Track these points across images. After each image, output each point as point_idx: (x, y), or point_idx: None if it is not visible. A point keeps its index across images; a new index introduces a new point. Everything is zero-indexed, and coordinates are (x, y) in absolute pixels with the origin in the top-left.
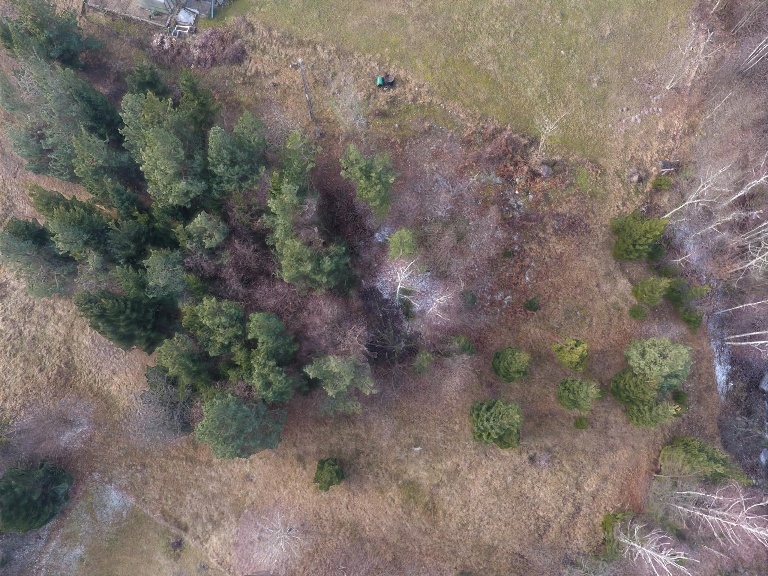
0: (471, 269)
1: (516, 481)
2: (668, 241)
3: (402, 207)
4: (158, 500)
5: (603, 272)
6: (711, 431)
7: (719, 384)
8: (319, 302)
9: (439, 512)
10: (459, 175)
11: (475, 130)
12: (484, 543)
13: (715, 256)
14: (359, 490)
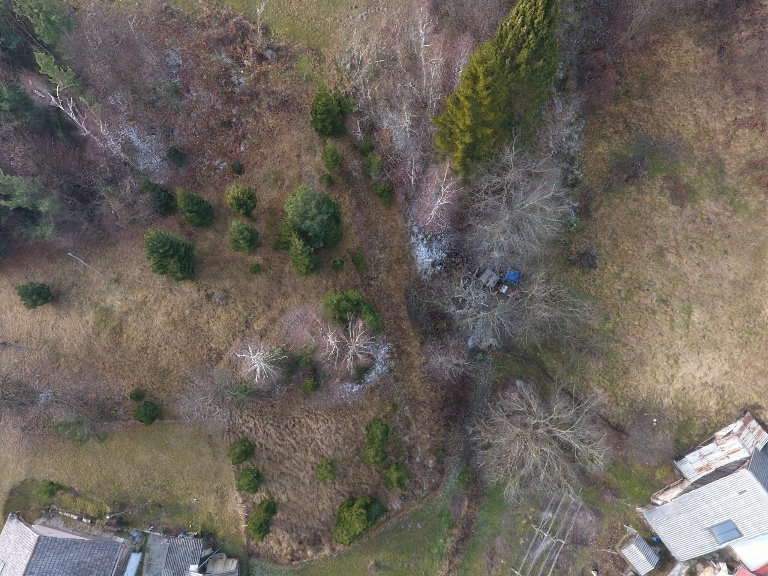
0: (193, 136)
1: (193, 315)
2: (372, 124)
3: (134, 75)
4: None
5: (307, 146)
6: (398, 300)
7: (420, 263)
8: (3, 126)
9: (124, 335)
10: (190, 52)
11: (210, 14)
12: (161, 367)
13: (425, 146)
14: (65, 314)
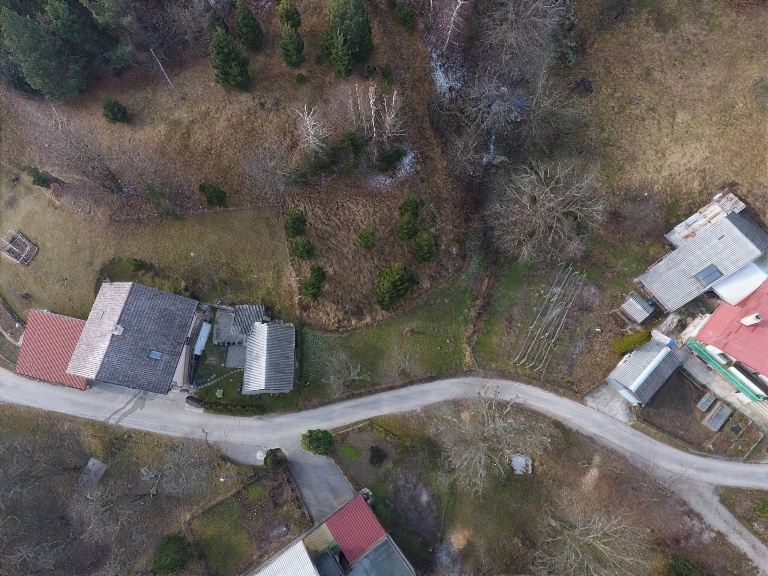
0: None
1: (250, 120)
2: None
3: None
4: (7, 152)
5: None
6: (421, 113)
7: (439, 86)
8: None
9: (191, 140)
10: None
11: None
12: (223, 165)
13: None
14: (140, 129)
